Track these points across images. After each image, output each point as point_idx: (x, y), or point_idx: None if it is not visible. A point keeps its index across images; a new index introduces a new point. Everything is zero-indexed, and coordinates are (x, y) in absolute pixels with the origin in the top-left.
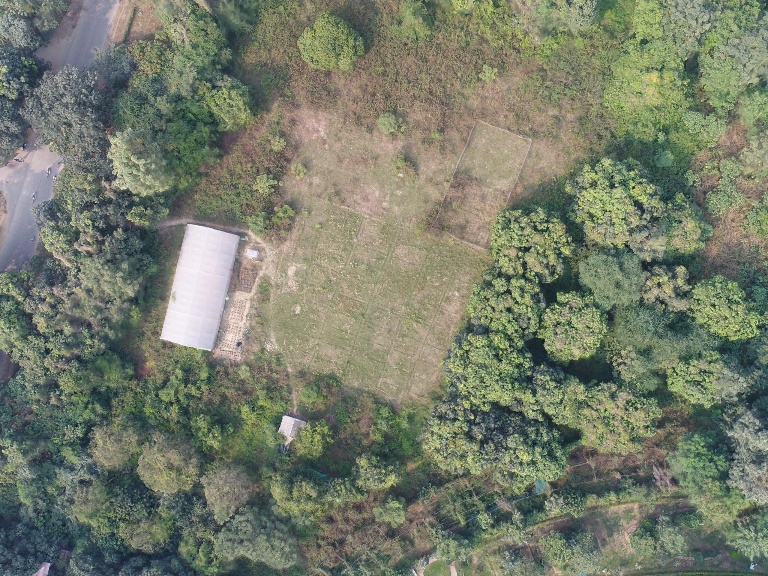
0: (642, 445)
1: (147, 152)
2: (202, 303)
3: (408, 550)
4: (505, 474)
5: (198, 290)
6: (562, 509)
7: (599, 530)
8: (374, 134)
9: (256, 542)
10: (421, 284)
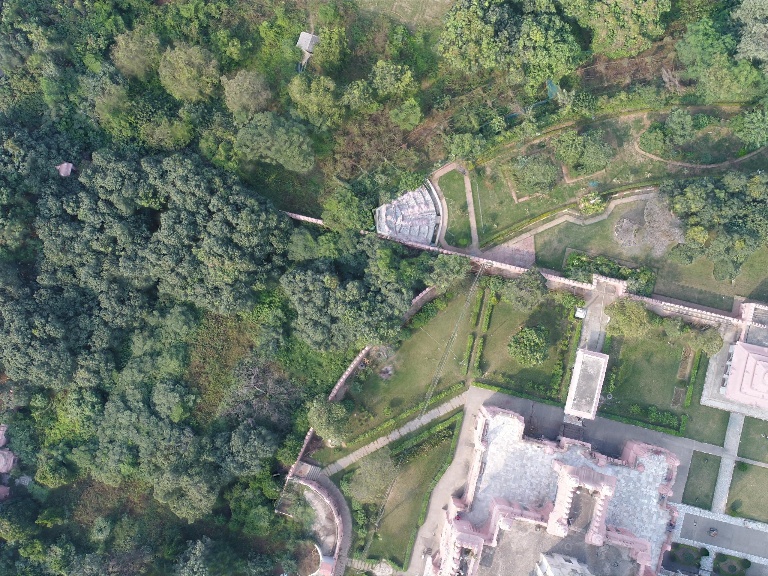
0: (651, 43)
1: None
2: None
3: (423, 161)
4: (518, 67)
5: None
6: (574, 105)
7: (609, 140)
8: None
9: (275, 138)
10: None
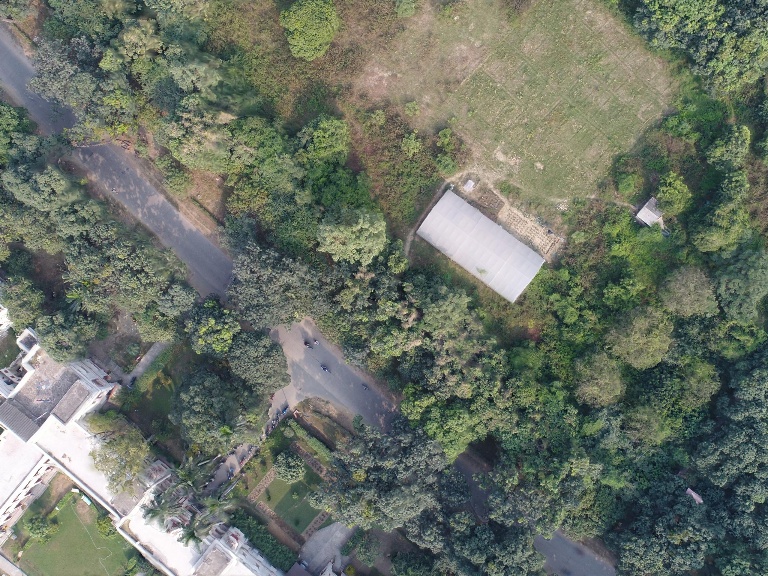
0: None
1: (349, 220)
2: (500, 246)
3: None
4: None
5: (486, 244)
6: None
7: None
8: (407, 27)
9: (752, 283)
10: (566, 41)
